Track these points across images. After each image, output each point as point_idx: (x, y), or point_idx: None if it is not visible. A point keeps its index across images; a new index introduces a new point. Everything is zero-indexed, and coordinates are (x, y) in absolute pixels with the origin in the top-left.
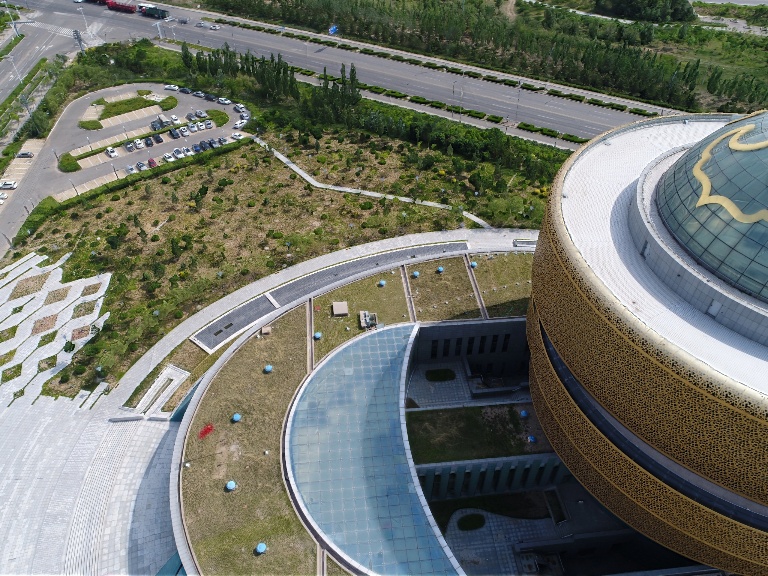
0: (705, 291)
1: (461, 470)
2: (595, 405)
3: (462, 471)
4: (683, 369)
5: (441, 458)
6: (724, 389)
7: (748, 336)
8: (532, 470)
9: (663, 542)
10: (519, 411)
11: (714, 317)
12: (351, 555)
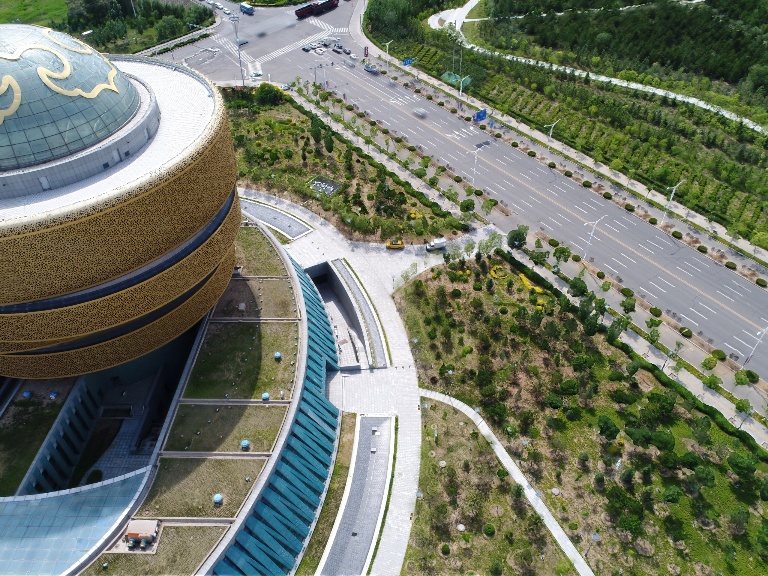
0: (29, 178)
1: (44, 461)
2: (61, 298)
3: (46, 461)
4: (74, 214)
5: (22, 472)
6: (101, 203)
7: (76, 181)
8: (79, 410)
9: (176, 334)
10: (21, 398)
11: (50, 189)
12: (65, 569)
